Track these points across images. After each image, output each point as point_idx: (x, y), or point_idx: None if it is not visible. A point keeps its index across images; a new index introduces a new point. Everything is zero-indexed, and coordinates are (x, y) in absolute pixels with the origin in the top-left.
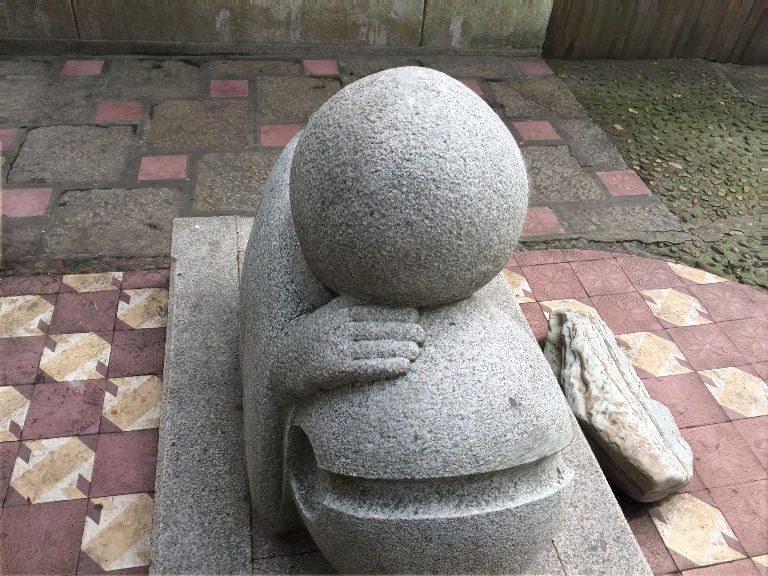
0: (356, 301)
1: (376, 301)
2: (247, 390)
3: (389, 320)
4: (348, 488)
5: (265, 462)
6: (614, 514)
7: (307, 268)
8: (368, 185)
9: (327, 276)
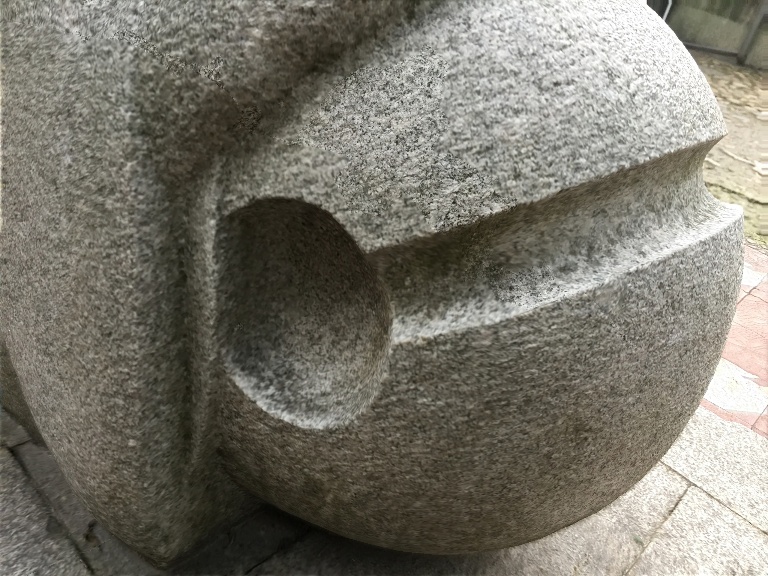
0: None
1: None
2: (29, 214)
3: None
4: (448, 281)
5: (148, 358)
6: None
7: None
8: None
9: None
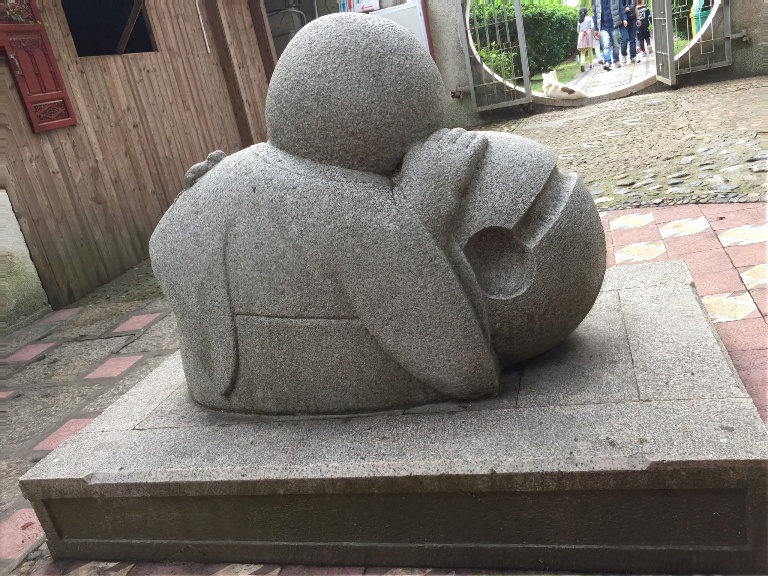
0: (421, 141)
1: (430, 132)
2: (401, 290)
3: (448, 131)
4: (531, 227)
5: (467, 304)
6: None
7: (361, 172)
8: (391, 44)
9: (397, 137)
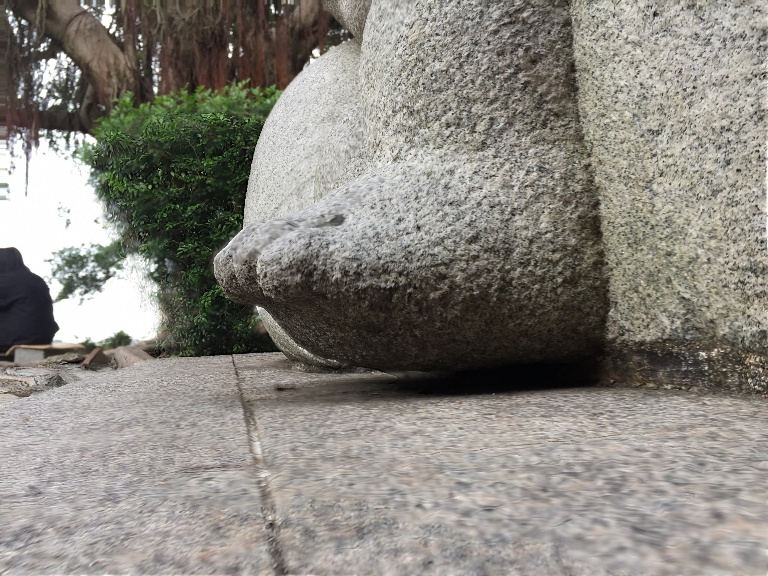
0: None
1: None
2: None
3: None
4: None
5: None
6: (137, 366)
7: None
8: None
9: None
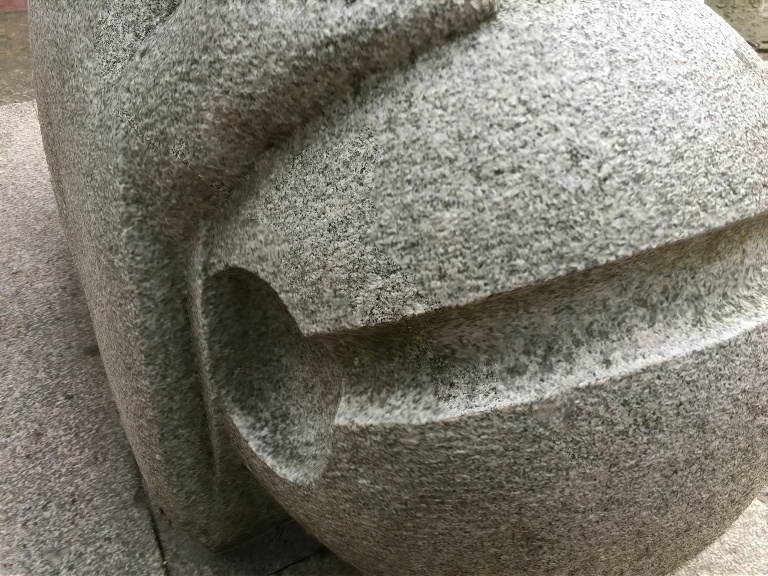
0: None
1: None
2: None
3: None
4: (393, 367)
5: (161, 391)
6: None
7: None
8: None
9: None
